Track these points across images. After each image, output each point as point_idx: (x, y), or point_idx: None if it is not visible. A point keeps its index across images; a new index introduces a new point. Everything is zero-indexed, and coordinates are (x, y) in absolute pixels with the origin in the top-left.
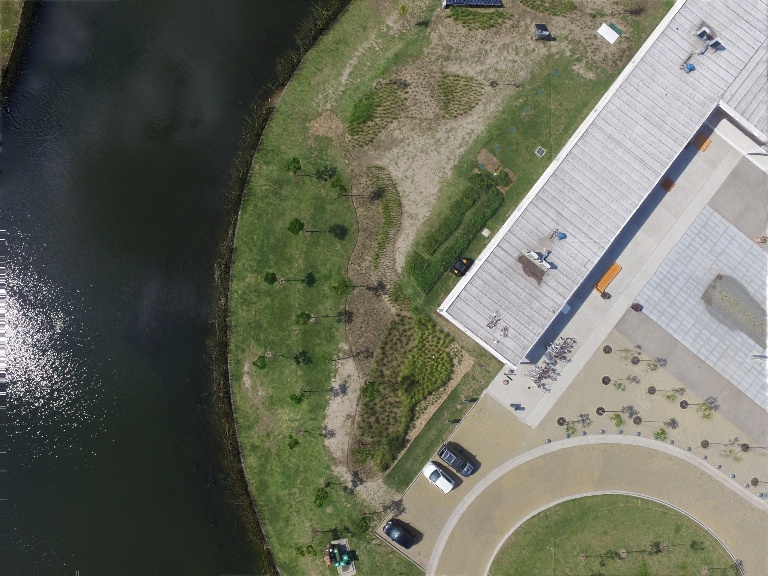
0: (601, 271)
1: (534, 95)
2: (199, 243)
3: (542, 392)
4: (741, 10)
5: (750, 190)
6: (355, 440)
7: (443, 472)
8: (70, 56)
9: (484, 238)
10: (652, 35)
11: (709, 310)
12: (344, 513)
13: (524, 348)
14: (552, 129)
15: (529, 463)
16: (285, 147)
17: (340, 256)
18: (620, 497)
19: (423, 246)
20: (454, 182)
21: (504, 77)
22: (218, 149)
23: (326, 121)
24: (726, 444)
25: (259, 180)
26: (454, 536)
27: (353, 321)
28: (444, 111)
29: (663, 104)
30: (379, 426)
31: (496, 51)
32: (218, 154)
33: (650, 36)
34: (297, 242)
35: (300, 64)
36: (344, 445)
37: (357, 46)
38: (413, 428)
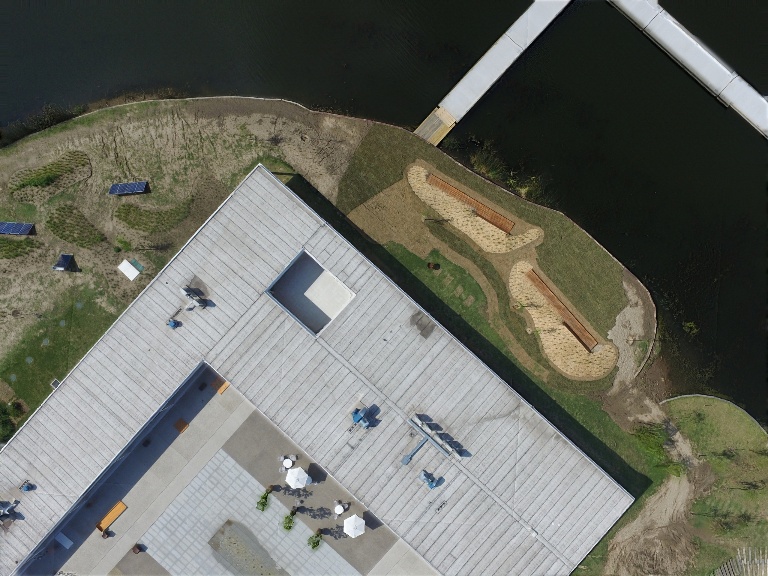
0: (106, 508)
1: (55, 326)
2: None
3: None
4: (236, 266)
5: (267, 436)
6: None
7: None
8: None
9: None
10: None
11: (215, 556)
12: None
13: None
14: (69, 362)
15: None
16: None
17: None
18: None
19: None
20: None
21: (27, 306)
22: None
23: None
24: None
25: None
26: None
27: None
28: None
29: (145, 360)
30: None
31: (20, 281)
32: None
33: None
34: None
35: None
36: None
37: None
38: None
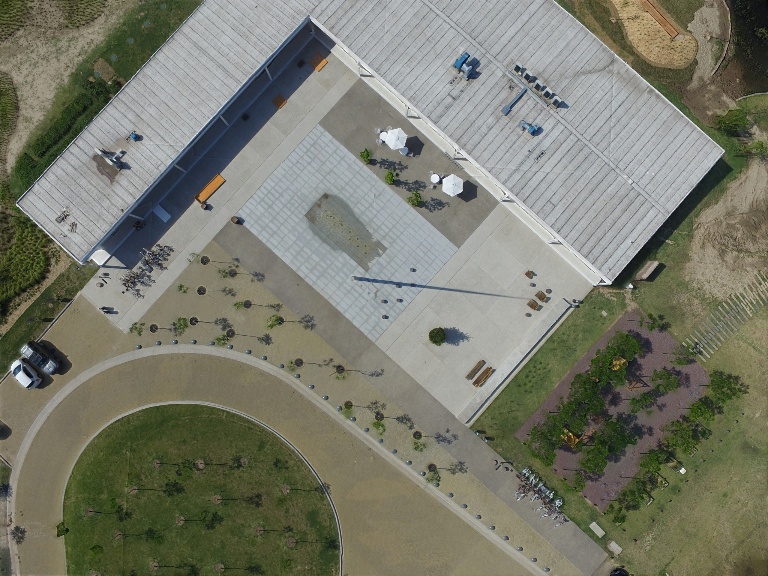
0: (204, 182)
1: (155, 9)
2: None
3: (134, 297)
4: None
5: (364, 112)
6: None
7: (29, 368)
8: None
9: None
10: None
11: (312, 228)
12: None
13: (90, 244)
14: None
15: (118, 367)
16: None
17: None
18: (205, 408)
19: (32, 148)
20: (70, 89)
21: None
22: None
23: None
24: (321, 364)
25: None
26: (41, 434)
27: None
28: (68, 21)
29: (252, 16)
30: None
31: None
32: None
33: None
34: None
35: None
36: None
37: None
38: (5, 323)
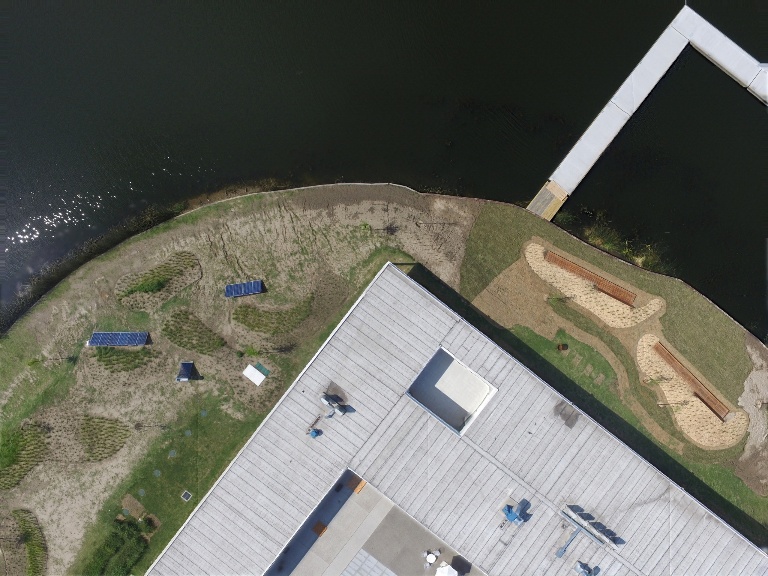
0: None
1: (180, 437)
2: None
3: None
4: (373, 369)
5: (408, 532)
6: None
7: None
8: None
9: None
10: None
11: None
12: None
13: None
14: (198, 473)
15: None
16: None
17: None
18: None
19: None
20: (98, 527)
21: (150, 418)
22: None
23: None
24: None
25: None
26: None
27: None
28: (89, 454)
29: (287, 471)
30: None
31: (140, 393)
32: None
33: None
34: None
35: None
36: None
37: (13, 377)
38: None
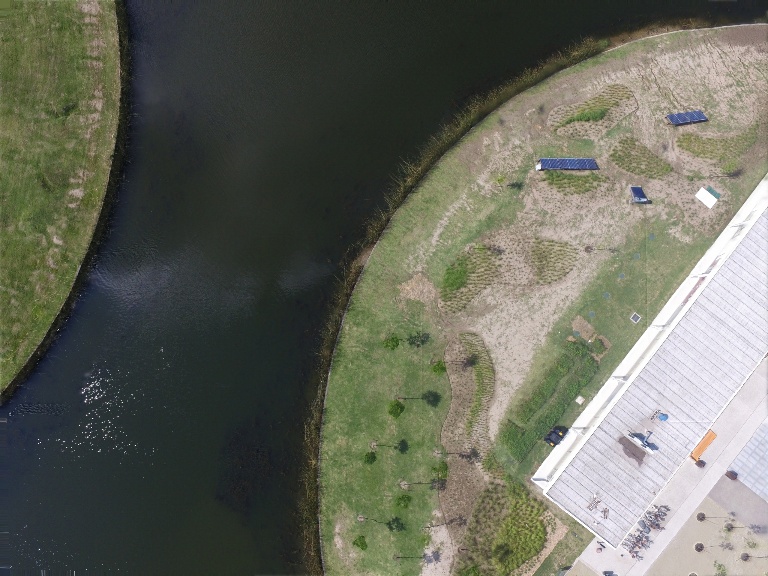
0: None
1: (629, 260)
2: (288, 401)
3: (635, 560)
4: None
5: None
6: None
7: None
8: (158, 214)
9: (578, 406)
10: (751, 198)
11: None
12: None
13: (624, 529)
14: (647, 295)
15: None
16: (375, 309)
17: (433, 423)
18: None
19: (517, 415)
20: (548, 349)
21: (599, 242)
22: (307, 307)
23: (417, 284)
24: None
25: (349, 341)
26: None
27: (446, 488)
28: (538, 277)
29: (767, 281)
30: None
31: (591, 216)
32: (306, 312)
33: (748, 199)
34: None
35: (389, 222)
36: None
37: (447, 205)
38: None
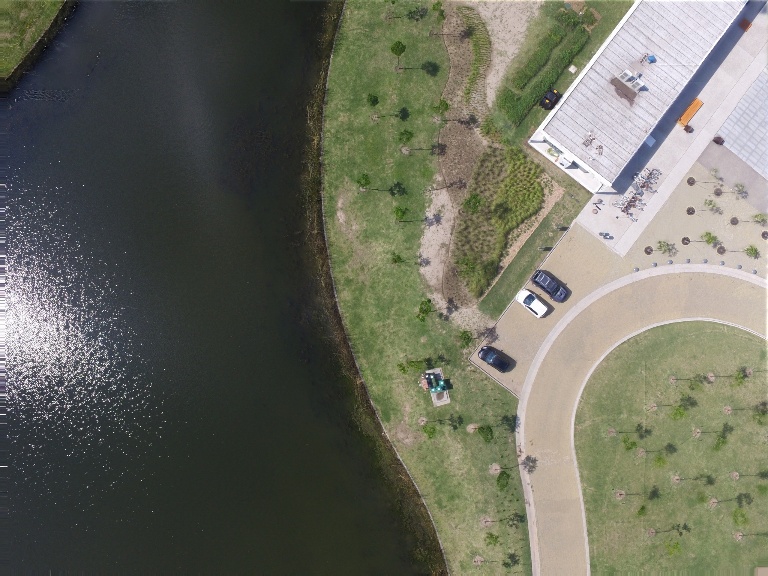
0: (683, 106)
1: None
2: (291, 88)
3: (630, 221)
4: None
5: None
6: (450, 268)
7: (536, 297)
8: None
9: (571, 74)
10: None
11: None
12: (439, 341)
13: (618, 166)
14: None
15: (618, 291)
16: None
17: (433, 91)
18: (707, 324)
19: (513, 80)
20: (541, 21)
21: None
22: None
23: None
24: None
25: (350, 24)
26: (546, 363)
27: (446, 153)
28: None
29: None
30: (473, 253)
31: None
32: (309, 2)
33: None
34: (390, 80)
35: None
36: (439, 273)
37: None
38: (506, 255)
